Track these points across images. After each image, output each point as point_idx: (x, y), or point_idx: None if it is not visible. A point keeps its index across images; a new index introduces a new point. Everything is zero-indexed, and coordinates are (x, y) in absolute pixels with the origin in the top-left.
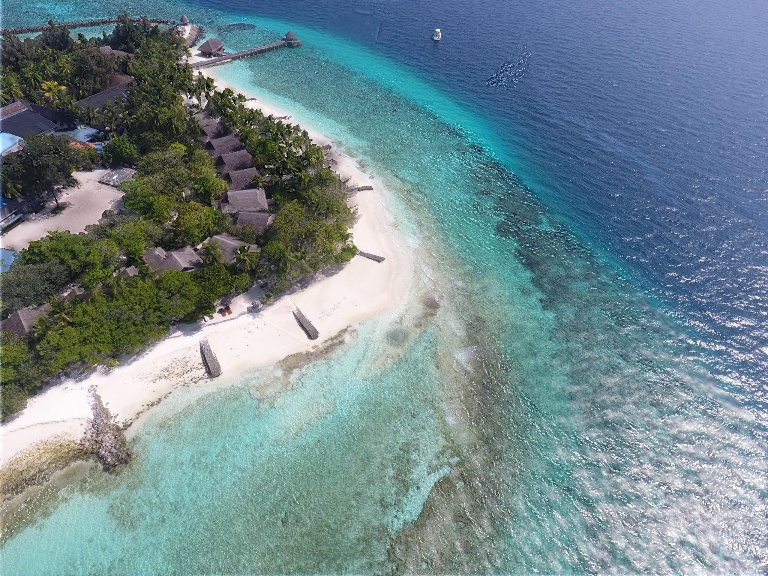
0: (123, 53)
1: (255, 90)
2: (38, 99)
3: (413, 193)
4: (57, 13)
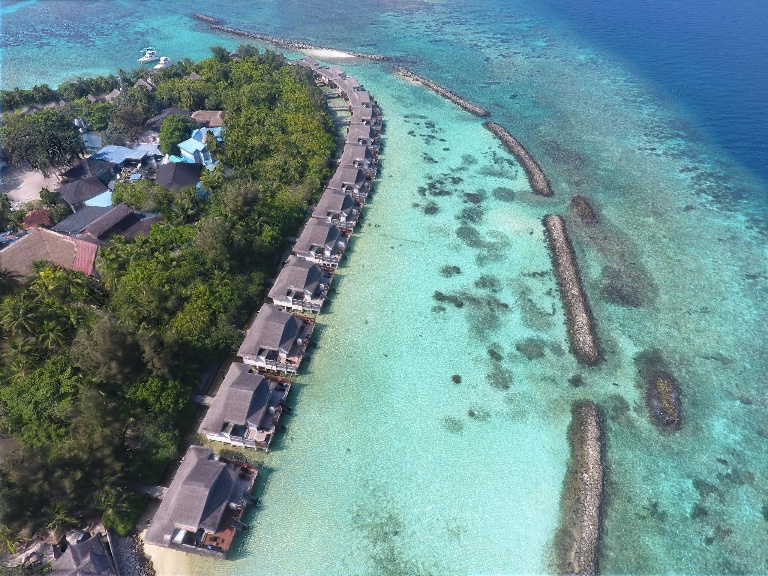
0: None
1: None
2: (78, 272)
3: None
4: None
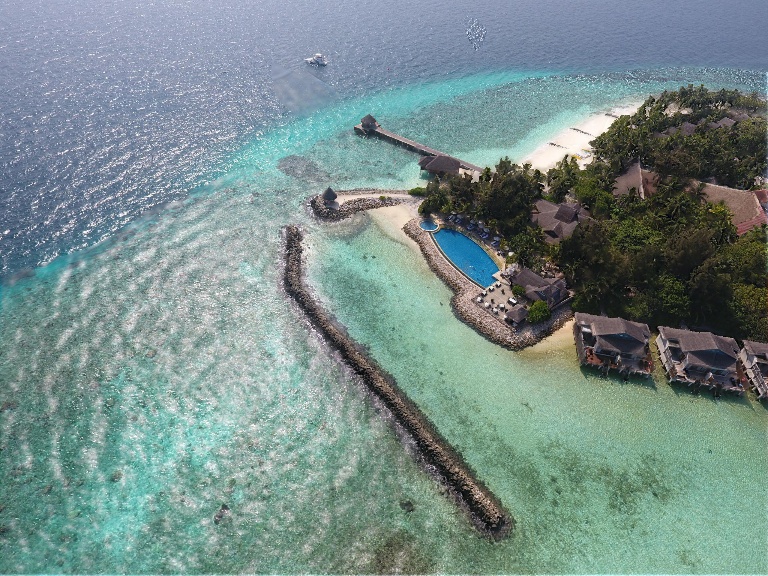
0: (547, 206)
1: (527, 145)
2: None
3: (635, 96)
4: (232, 429)
